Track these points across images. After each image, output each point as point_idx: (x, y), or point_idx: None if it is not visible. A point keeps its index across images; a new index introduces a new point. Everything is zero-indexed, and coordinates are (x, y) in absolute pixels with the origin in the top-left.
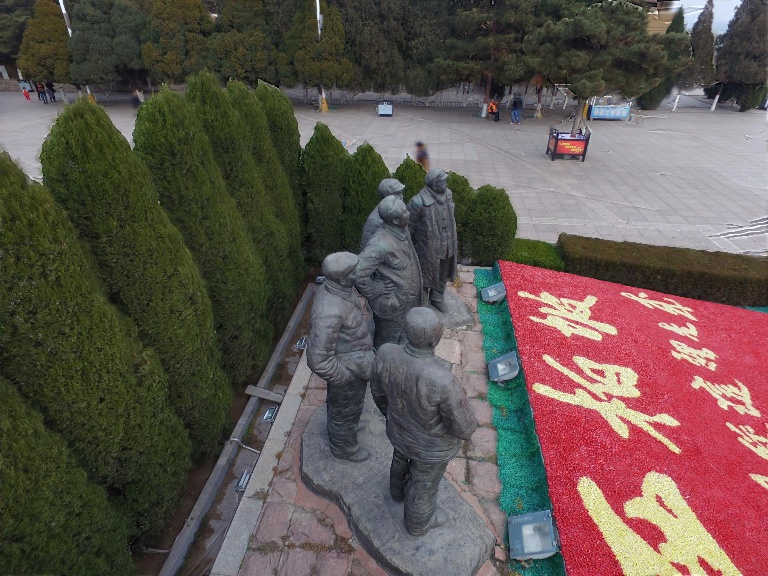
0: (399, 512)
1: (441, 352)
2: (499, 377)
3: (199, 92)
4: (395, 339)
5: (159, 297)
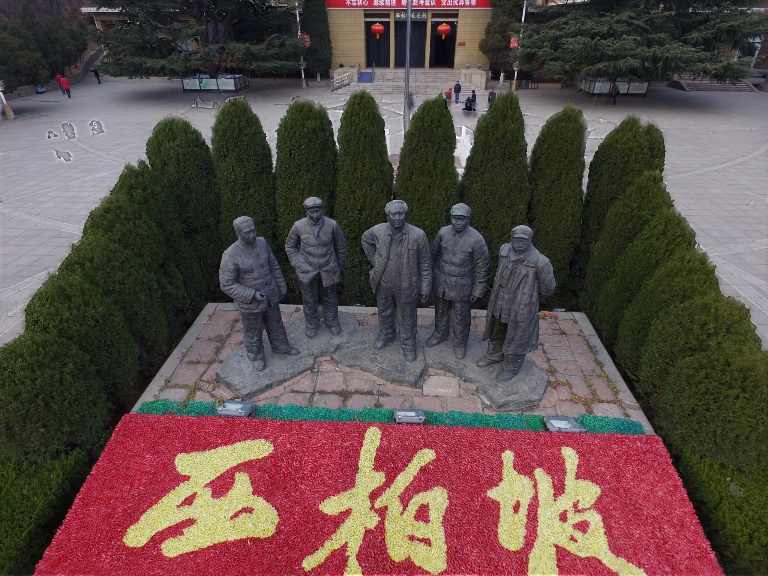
0: (267, 350)
1: (435, 380)
2: (395, 411)
3: (494, 105)
4: (379, 309)
5: (343, 197)
